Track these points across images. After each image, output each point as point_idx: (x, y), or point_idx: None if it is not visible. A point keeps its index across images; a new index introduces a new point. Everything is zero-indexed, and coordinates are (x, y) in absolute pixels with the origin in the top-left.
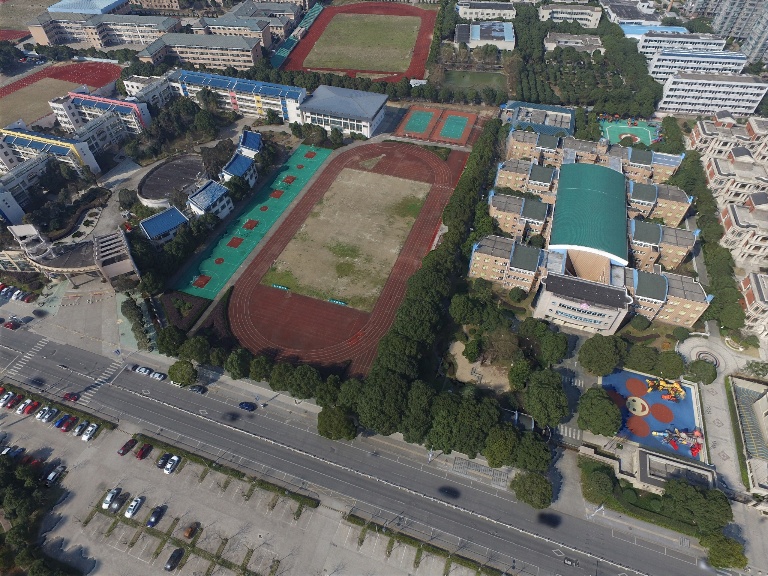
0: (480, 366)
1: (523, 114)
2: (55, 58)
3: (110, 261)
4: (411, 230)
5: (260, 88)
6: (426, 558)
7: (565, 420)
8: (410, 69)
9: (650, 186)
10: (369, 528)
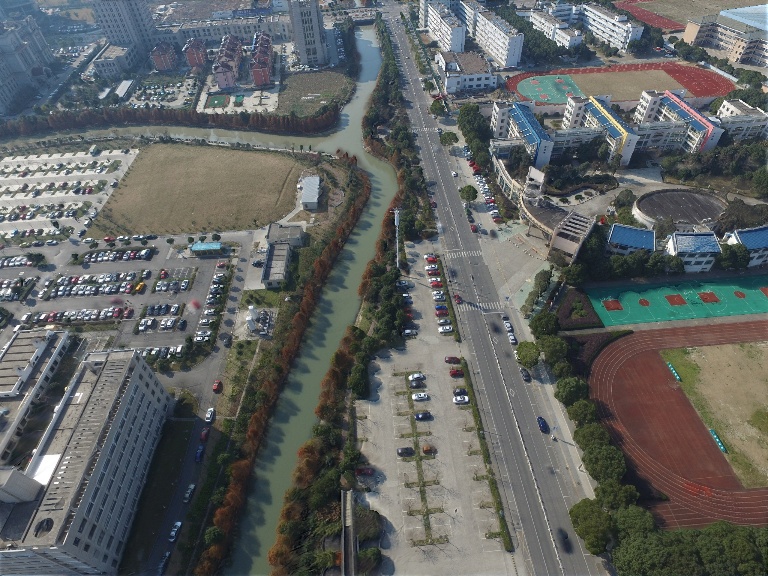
0: None
1: None
2: (685, 56)
3: (565, 235)
4: None
5: None
6: None
7: None
8: None
9: None
10: None
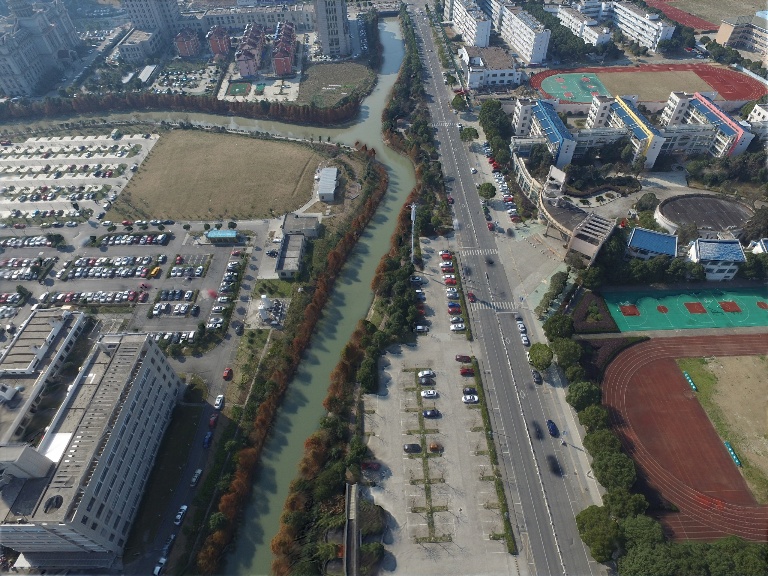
0: None
1: None
2: (717, 58)
3: (584, 237)
4: None
5: None
6: None
7: None
8: None
9: None
10: None
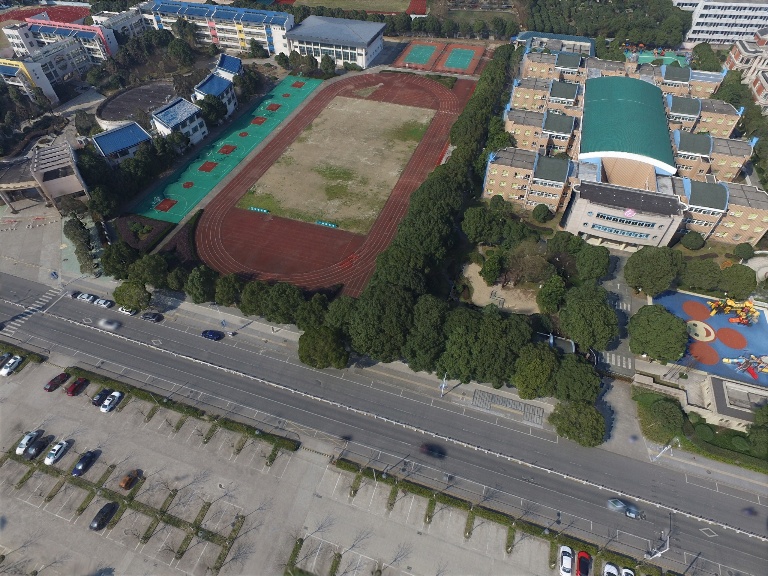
0: (501, 289)
1: (537, 43)
2: (21, 2)
3: (52, 175)
4: (413, 153)
5: (242, 15)
6: (441, 511)
7: (611, 347)
8: (409, 9)
9: (692, 99)
10: (365, 474)
